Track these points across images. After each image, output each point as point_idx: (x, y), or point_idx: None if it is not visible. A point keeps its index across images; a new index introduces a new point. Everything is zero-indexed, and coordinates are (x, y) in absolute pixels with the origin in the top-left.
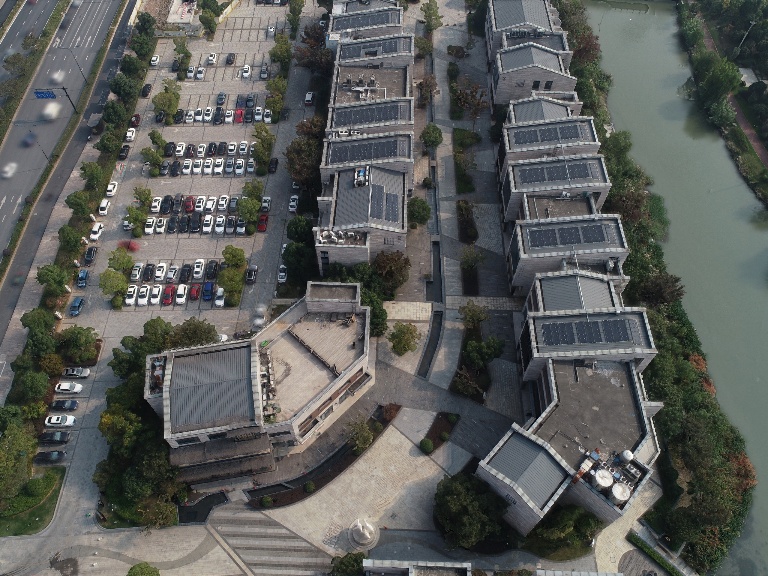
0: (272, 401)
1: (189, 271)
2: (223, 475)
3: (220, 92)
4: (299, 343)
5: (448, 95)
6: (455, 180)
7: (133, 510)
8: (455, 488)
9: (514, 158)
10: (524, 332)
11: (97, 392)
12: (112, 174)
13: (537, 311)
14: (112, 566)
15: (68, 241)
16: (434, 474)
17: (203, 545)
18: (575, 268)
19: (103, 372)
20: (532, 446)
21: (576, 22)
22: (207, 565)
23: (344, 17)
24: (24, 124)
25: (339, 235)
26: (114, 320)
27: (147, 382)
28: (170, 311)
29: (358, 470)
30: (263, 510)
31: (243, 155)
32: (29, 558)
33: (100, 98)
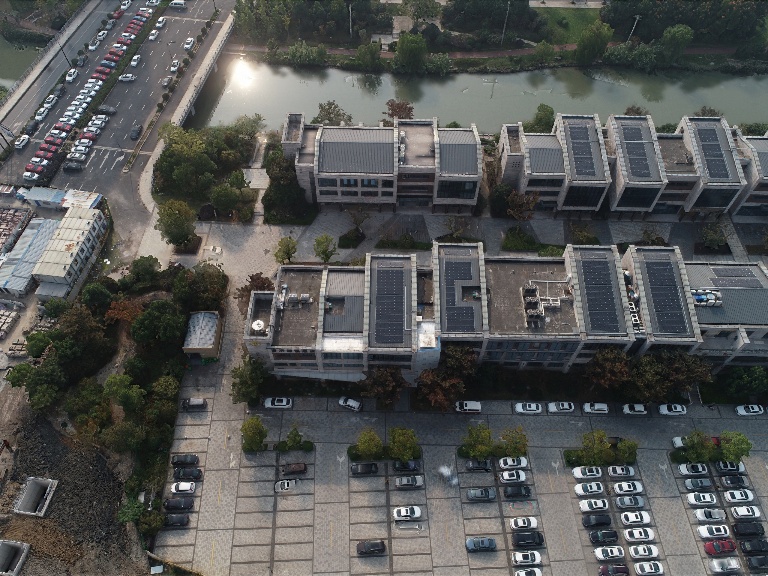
0: None
1: None
2: None
3: (469, 548)
4: None
5: None
6: None
7: None
8: None
9: None
10: None
11: None
12: None
13: None
14: None
15: None
16: None
17: None
18: None
19: None
20: None
21: (341, 117)
22: None
23: (370, 332)
24: None
25: None
26: None
27: None
28: None
29: None
30: None
31: None
32: None
33: None
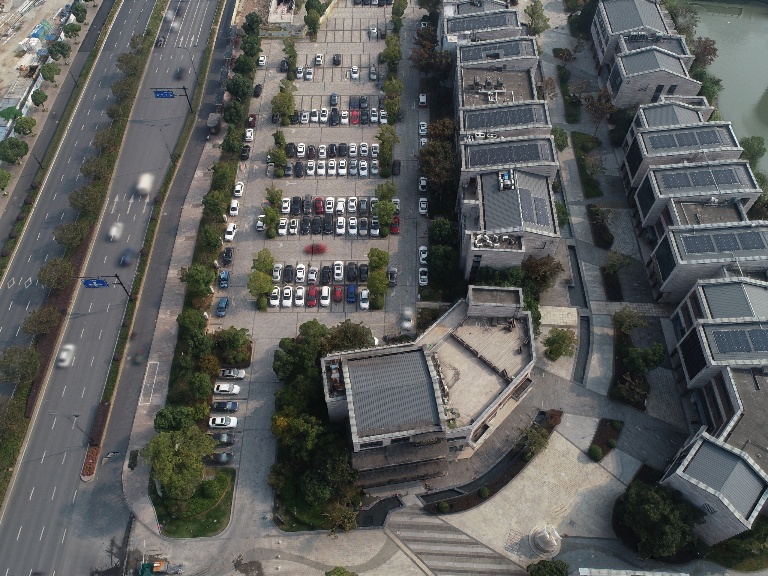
0: (446, 406)
1: (329, 273)
2: (400, 479)
3: (332, 93)
4: (463, 347)
5: (561, 98)
6: (581, 184)
7: (311, 513)
8: (652, 497)
9: (652, 163)
10: (689, 339)
11: (255, 394)
12: (236, 174)
13: (700, 318)
14: (297, 570)
15: (209, 241)
16: (606, 481)
17: (385, 550)
18: (734, 275)
19: (258, 374)
20: (727, 455)
21: (686, 26)
22: (392, 570)
23: (458, 19)
24: (141, 123)
25: (493, 239)
26: (261, 321)
27: (326, 385)
28: (315, 313)
29: (529, 476)
30: (439, 515)
31: (364, 157)
32: (212, 560)
33: (216, 98)
